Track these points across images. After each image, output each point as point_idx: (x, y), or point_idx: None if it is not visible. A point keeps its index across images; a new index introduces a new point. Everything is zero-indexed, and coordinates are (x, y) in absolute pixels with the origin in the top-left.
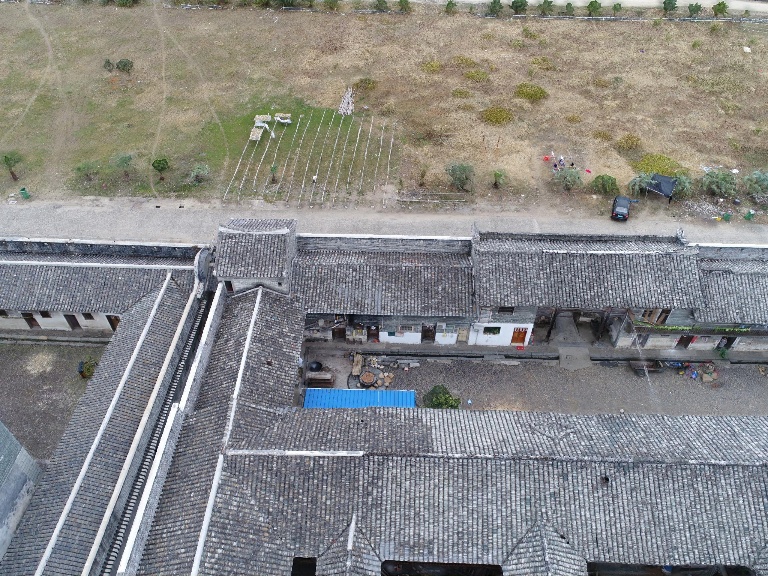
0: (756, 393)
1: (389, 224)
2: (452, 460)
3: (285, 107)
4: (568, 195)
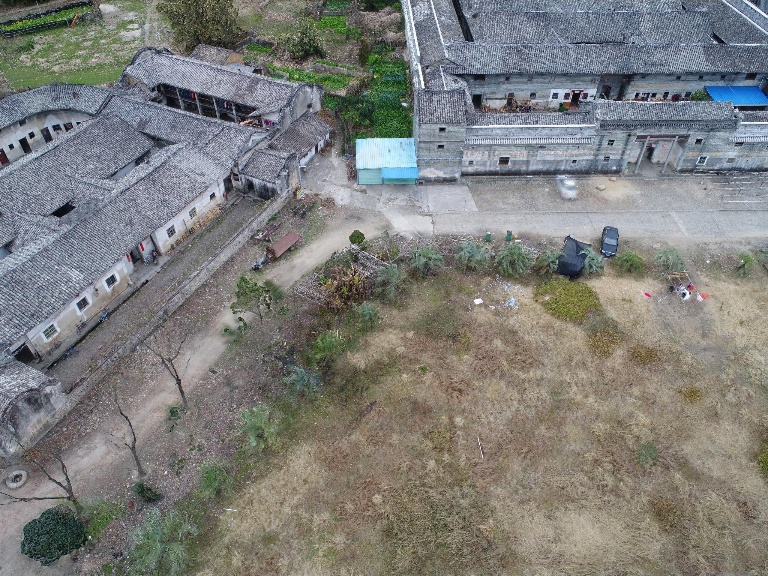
0: None
1: None
2: None
3: None
4: None
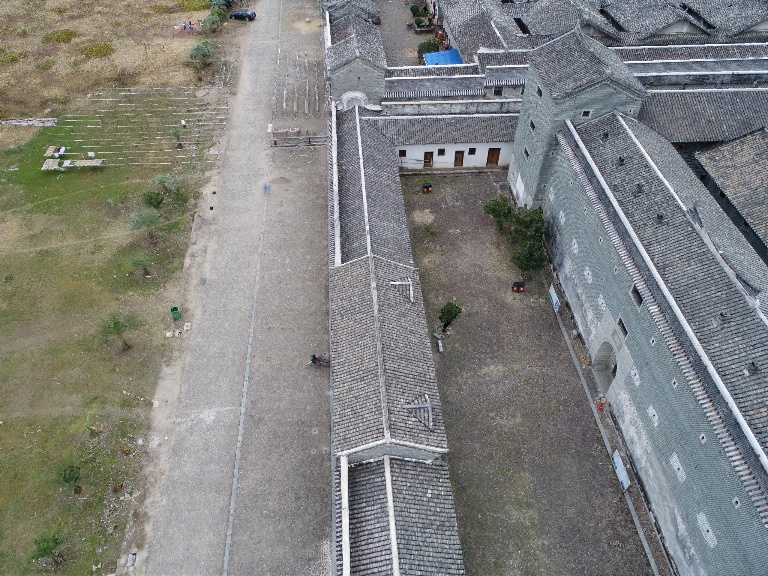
0: (384, 4)
1: (252, 90)
2: (485, 8)
3: (17, 161)
4: (222, 32)
